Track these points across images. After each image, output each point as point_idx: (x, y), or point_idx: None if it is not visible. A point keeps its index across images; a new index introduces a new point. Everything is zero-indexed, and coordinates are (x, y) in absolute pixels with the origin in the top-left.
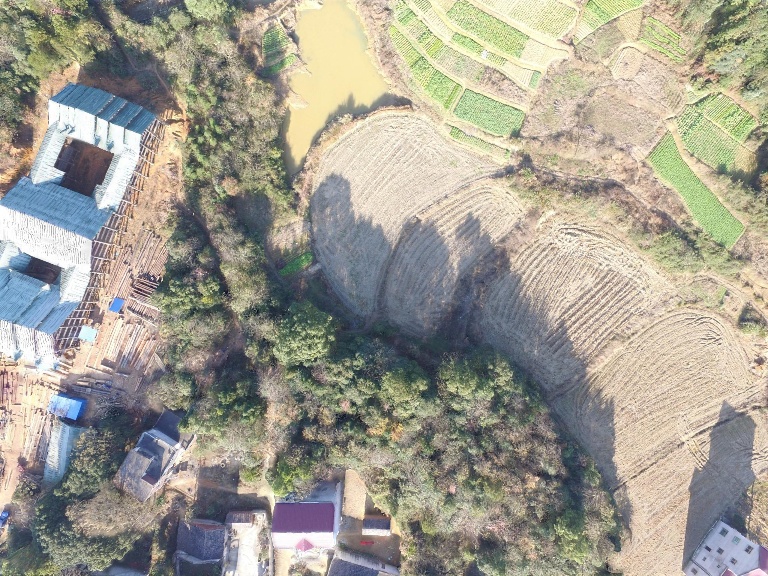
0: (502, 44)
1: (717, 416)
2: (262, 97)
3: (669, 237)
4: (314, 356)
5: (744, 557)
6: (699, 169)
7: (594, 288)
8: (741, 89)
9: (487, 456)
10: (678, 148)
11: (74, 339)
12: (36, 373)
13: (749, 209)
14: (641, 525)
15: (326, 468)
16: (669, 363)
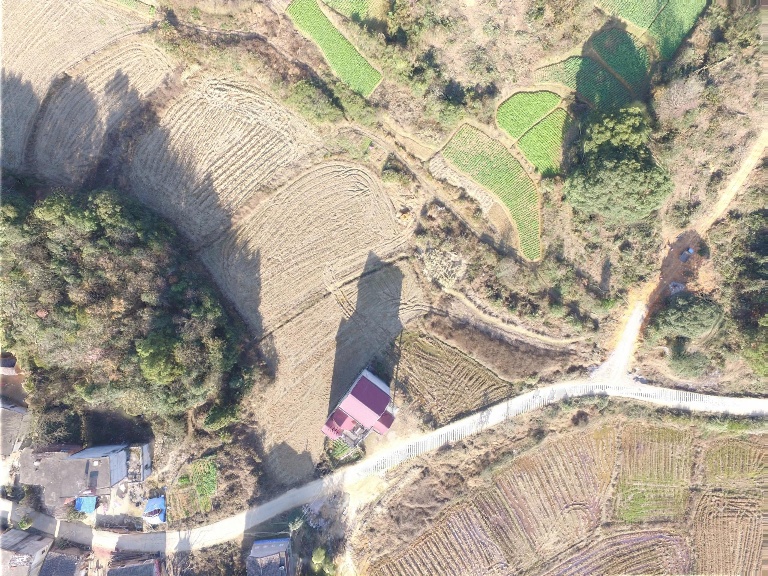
0: None
1: (363, 266)
2: None
3: (302, 85)
4: None
5: None
6: (333, 19)
7: (241, 141)
8: None
9: (82, 284)
10: None
11: None
12: None
13: None
14: (288, 374)
15: None
16: (316, 214)
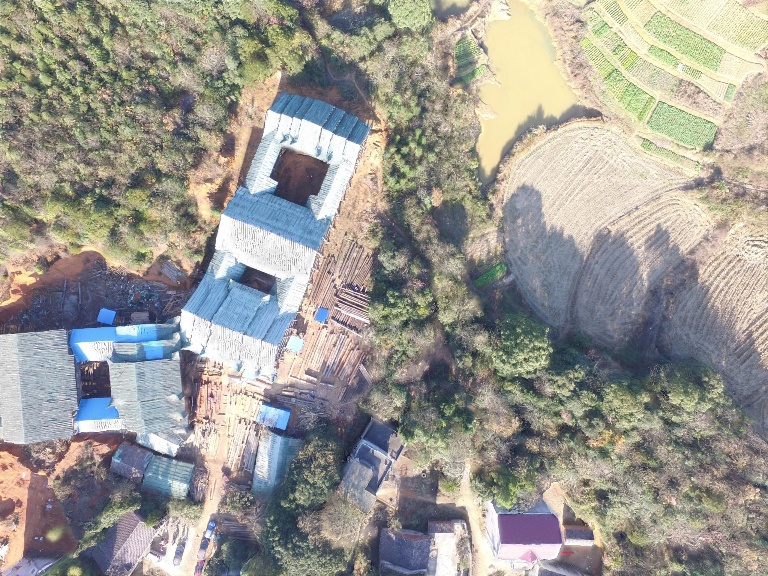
0: (699, 57)
1: None
2: (466, 108)
3: None
4: (534, 368)
5: None
6: None
7: None
8: None
9: (704, 468)
10: None
11: (283, 349)
12: (240, 383)
13: None
14: None
15: (547, 479)
16: None
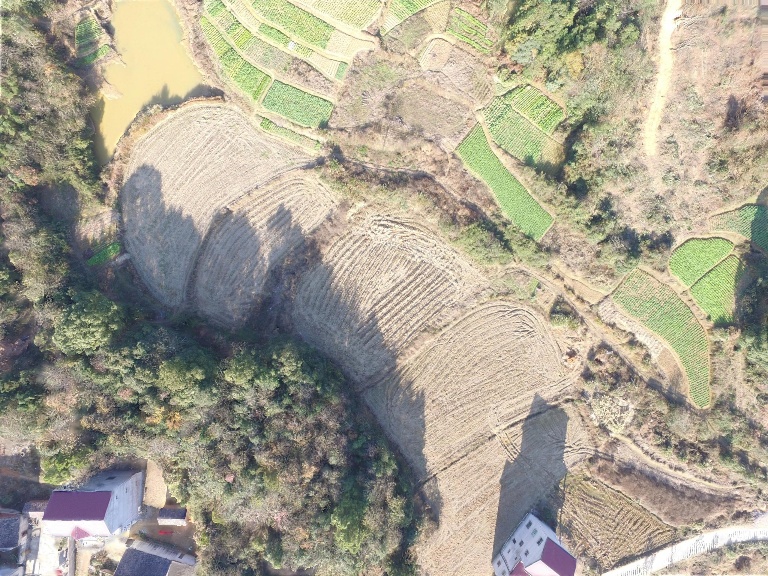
0: (307, 35)
1: (528, 409)
2: (62, 87)
3: (475, 229)
4: (96, 345)
5: (534, 549)
6: (506, 161)
7: (406, 280)
8: (545, 80)
9: (268, 446)
10: (487, 140)
11: None
12: None
13: (553, 201)
14: (451, 517)
15: (105, 457)
16: (481, 355)
